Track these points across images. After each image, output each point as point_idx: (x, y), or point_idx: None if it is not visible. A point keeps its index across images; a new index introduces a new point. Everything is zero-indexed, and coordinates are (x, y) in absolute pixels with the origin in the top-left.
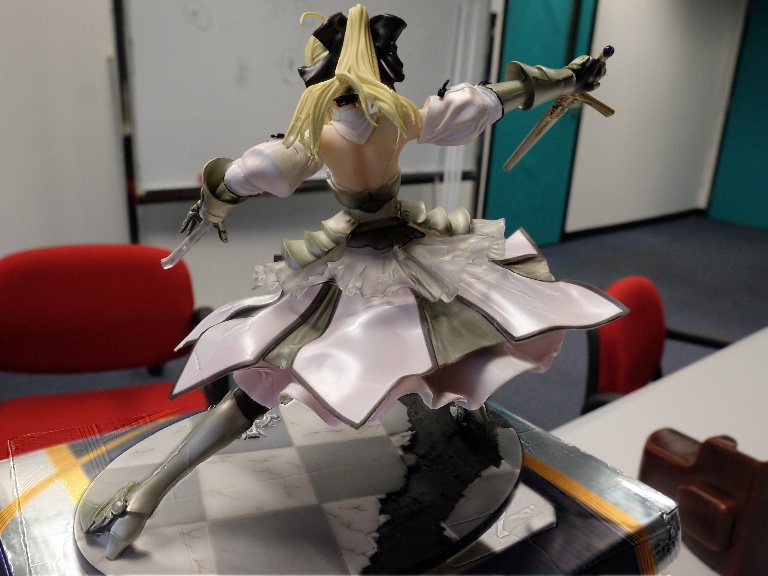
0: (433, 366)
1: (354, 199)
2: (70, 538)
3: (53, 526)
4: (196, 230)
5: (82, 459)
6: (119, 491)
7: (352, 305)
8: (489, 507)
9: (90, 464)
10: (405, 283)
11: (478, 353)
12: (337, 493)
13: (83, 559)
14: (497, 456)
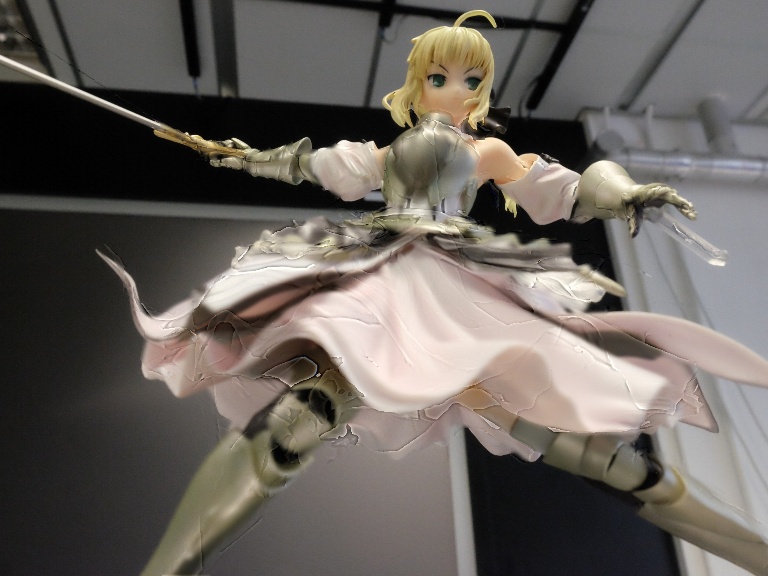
0: (425, 416)
1: None
2: None
3: None
4: None
5: None
6: None
7: None
8: None
9: None
10: None
11: (373, 414)
12: None
13: None
14: None
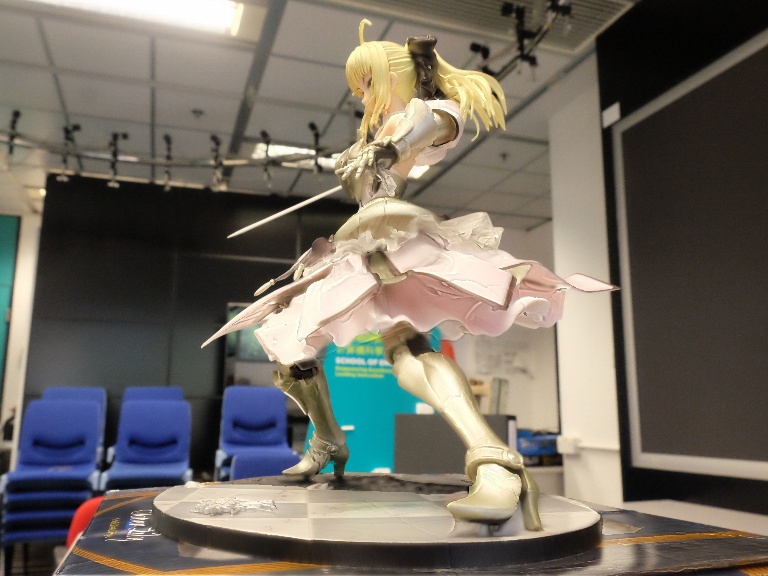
0: None
1: (400, 186)
2: (469, 569)
3: (437, 575)
4: (383, 167)
5: (223, 575)
6: (483, 456)
7: (477, 254)
8: (451, 479)
9: (247, 571)
10: (499, 236)
11: None
12: (410, 500)
13: (538, 542)
14: (374, 477)
